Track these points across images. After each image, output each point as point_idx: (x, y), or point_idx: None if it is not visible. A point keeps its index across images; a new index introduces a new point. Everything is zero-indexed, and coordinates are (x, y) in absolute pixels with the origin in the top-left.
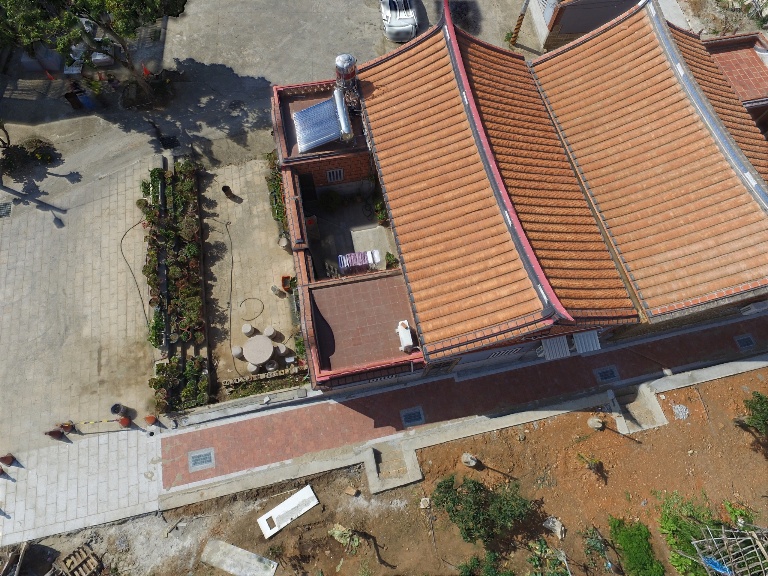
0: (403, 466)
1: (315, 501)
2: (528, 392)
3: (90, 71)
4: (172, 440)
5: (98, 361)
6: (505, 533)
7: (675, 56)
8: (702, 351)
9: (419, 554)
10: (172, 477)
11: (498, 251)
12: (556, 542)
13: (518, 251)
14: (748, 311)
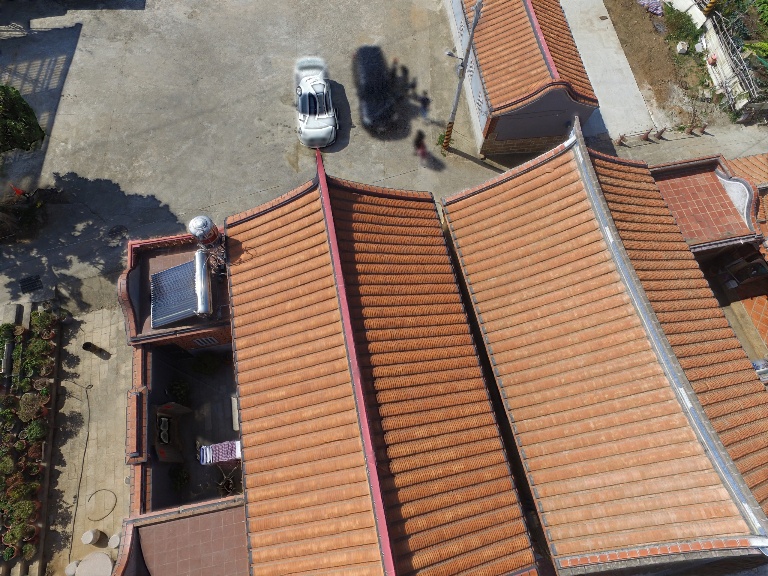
0: None
1: None
2: None
3: None
4: None
5: None
6: None
7: (603, 217)
8: None
9: None
10: None
11: (353, 509)
12: None
13: (374, 516)
14: None
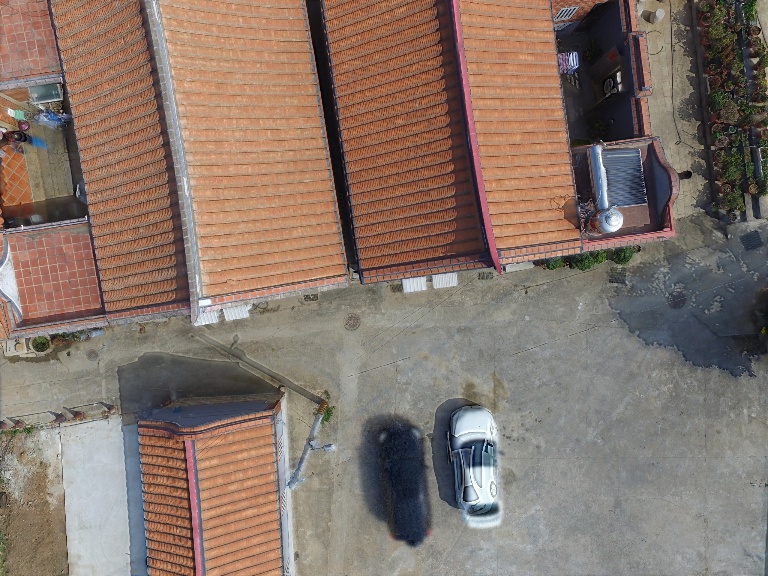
0: None
1: None
2: None
3: None
4: None
5: None
6: None
7: None
8: None
9: None
10: None
11: None
12: None
13: None
14: None
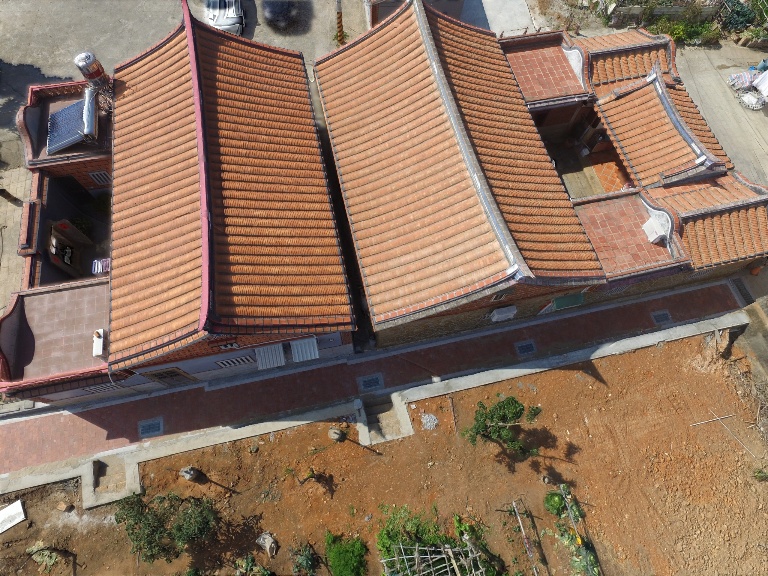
0: (124, 480)
1: (21, 517)
2: (281, 402)
3: None
4: None
5: None
6: (214, 550)
7: (431, 54)
8: (478, 358)
9: (119, 573)
10: None
11: (190, 256)
12: (265, 560)
13: None
14: (494, 317)
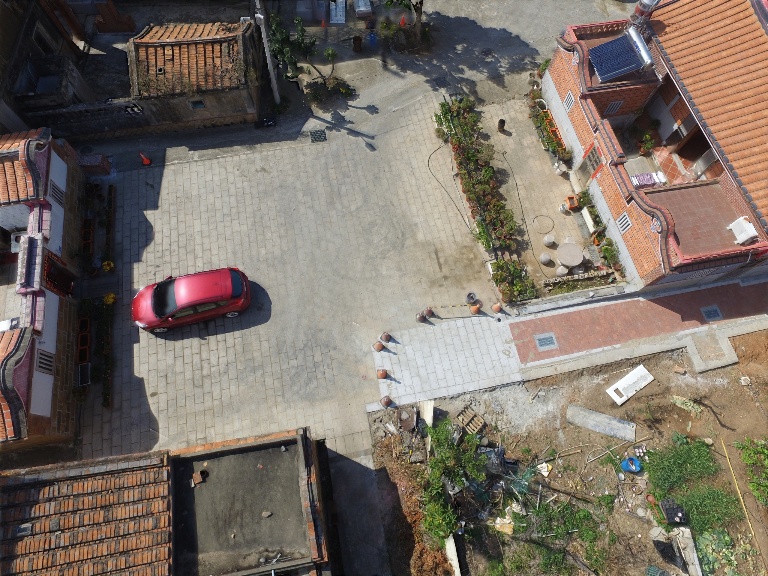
0: (719, 351)
1: (652, 377)
2: None
3: (352, 21)
4: (518, 325)
5: (437, 260)
6: None
7: None
8: None
9: (753, 421)
10: (526, 355)
11: None
12: None
13: None
14: None
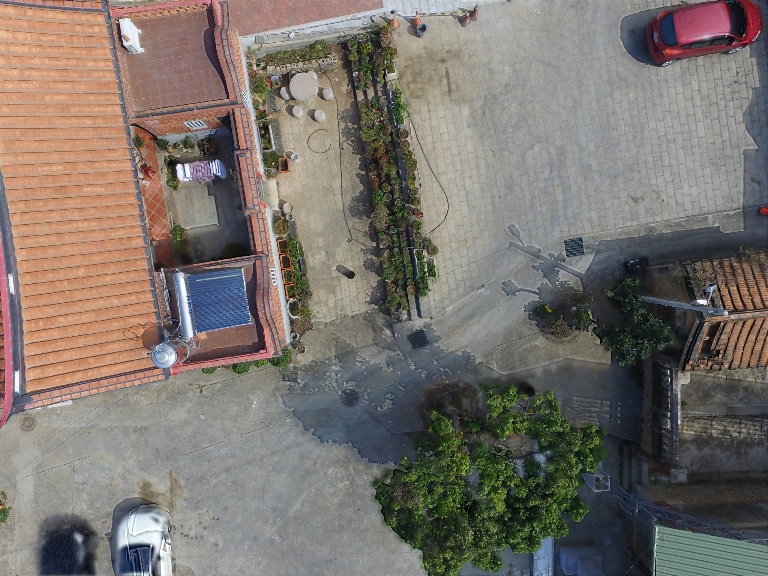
0: None
1: None
2: None
3: None
4: (374, 6)
5: (449, 81)
6: None
7: None
8: None
9: None
10: None
11: (3, 83)
12: None
13: None
14: None
